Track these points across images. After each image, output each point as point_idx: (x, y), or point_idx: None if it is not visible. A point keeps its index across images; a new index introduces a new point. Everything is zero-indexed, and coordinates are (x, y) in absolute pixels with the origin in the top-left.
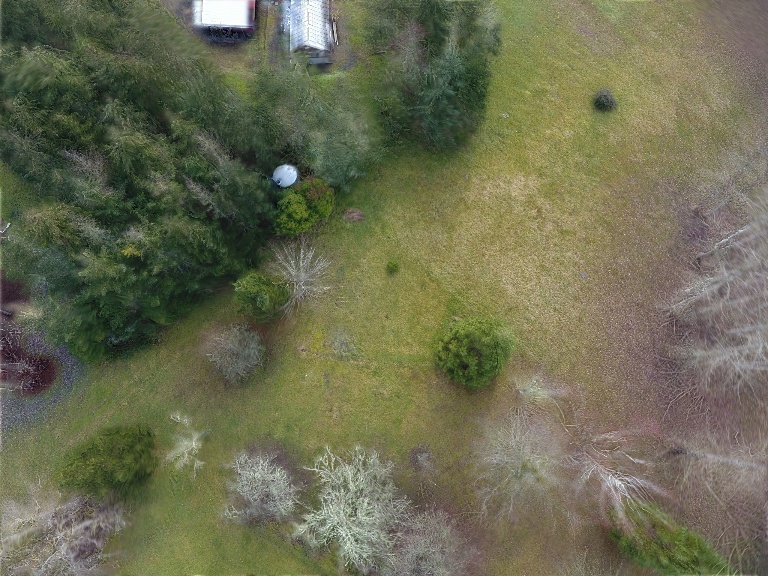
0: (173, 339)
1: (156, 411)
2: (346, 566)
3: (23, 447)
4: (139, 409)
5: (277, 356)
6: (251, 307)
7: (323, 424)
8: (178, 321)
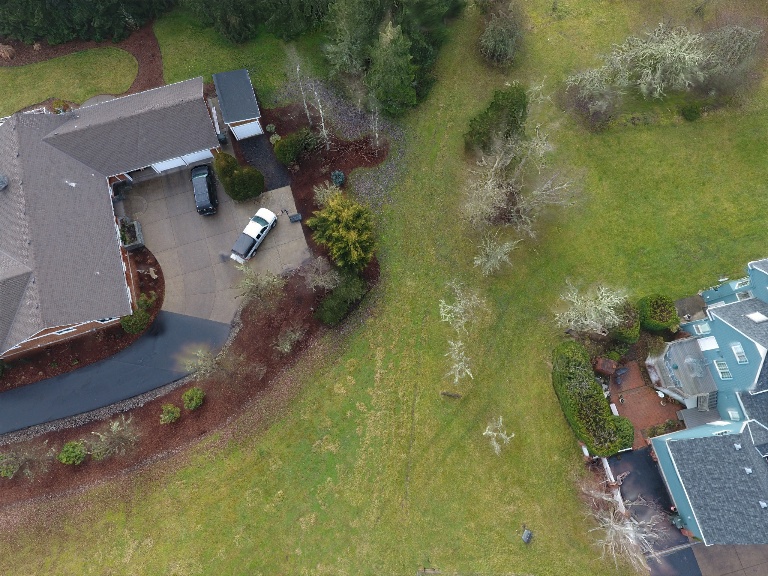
0: (443, 71)
1: (474, 114)
2: (697, 65)
3: (406, 189)
4: (462, 120)
5: (520, 40)
6: (491, 1)
7: (585, 57)
8: (437, 58)
